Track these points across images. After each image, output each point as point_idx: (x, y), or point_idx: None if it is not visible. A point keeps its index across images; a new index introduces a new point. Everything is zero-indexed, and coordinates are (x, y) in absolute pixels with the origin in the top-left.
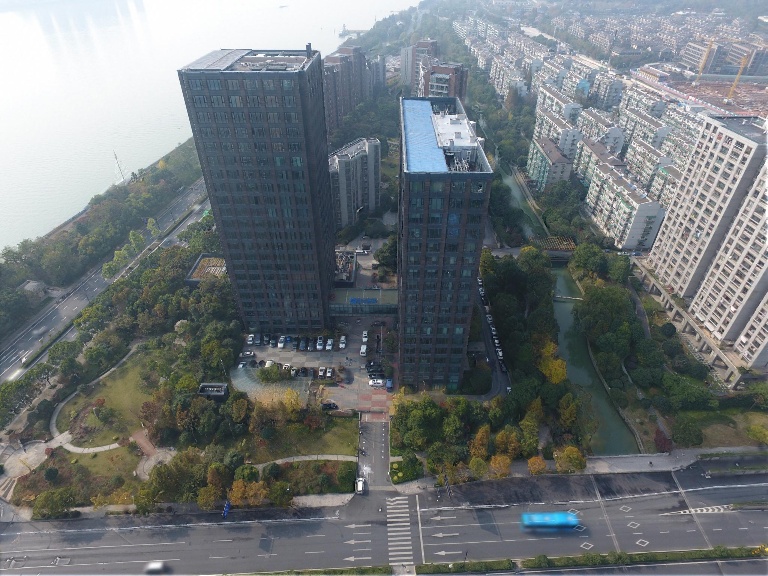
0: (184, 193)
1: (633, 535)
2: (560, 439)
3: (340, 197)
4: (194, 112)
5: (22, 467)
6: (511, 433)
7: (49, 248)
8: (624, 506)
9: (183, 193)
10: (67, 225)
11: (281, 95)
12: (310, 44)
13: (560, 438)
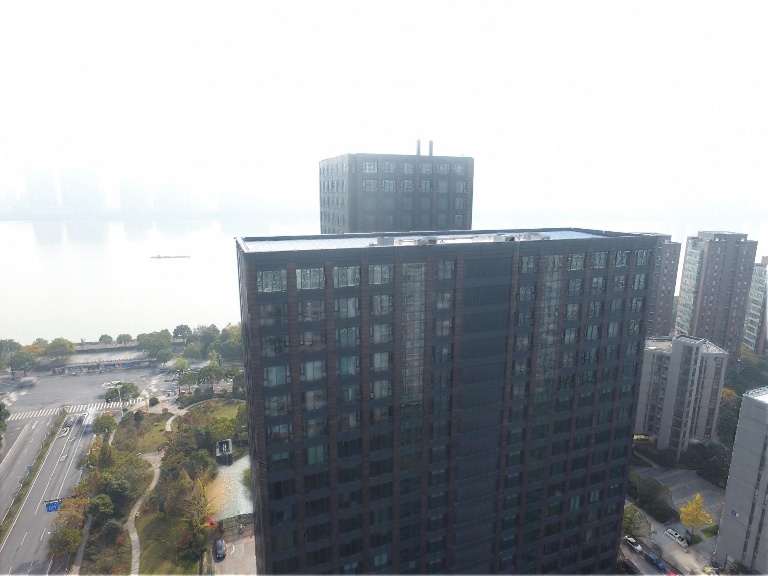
0: None
1: None
2: None
3: None
4: (320, 197)
5: (156, 410)
6: None
7: None
8: None
9: None
10: None
11: (342, 179)
12: (431, 141)
13: None
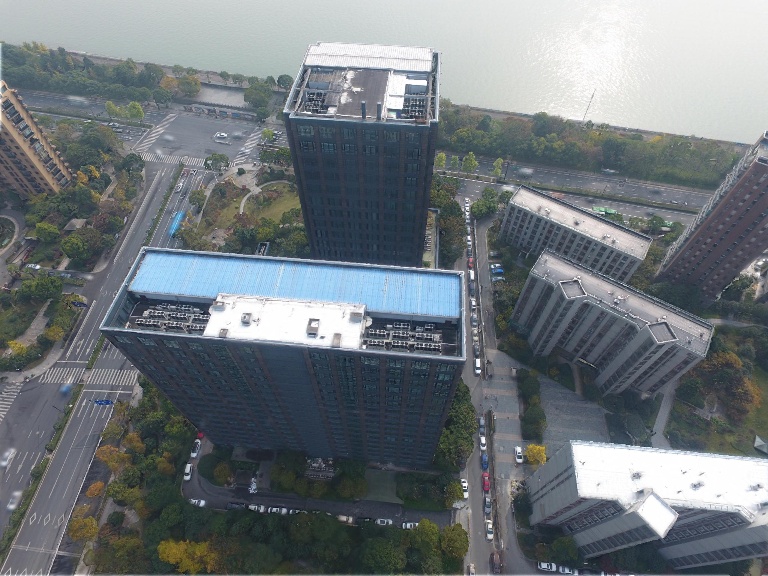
0: (608, 177)
1: (17, 568)
2: (115, 530)
3: (541, 315)
4: None
5: (241, 181)
6: (126, 470)
7: (454, 116)
8: (41, 575)
9: (608, 176)
10: (511, 116)
11: None
12: (379, 105)
13: (116, 530)
